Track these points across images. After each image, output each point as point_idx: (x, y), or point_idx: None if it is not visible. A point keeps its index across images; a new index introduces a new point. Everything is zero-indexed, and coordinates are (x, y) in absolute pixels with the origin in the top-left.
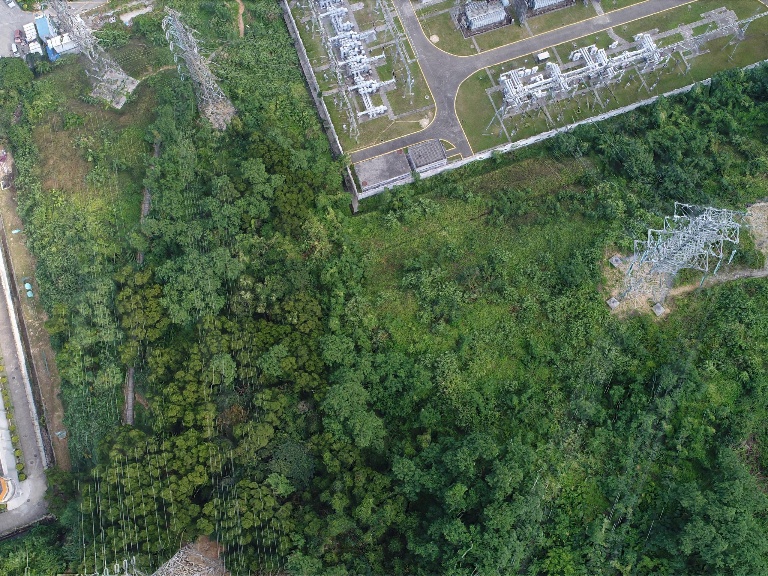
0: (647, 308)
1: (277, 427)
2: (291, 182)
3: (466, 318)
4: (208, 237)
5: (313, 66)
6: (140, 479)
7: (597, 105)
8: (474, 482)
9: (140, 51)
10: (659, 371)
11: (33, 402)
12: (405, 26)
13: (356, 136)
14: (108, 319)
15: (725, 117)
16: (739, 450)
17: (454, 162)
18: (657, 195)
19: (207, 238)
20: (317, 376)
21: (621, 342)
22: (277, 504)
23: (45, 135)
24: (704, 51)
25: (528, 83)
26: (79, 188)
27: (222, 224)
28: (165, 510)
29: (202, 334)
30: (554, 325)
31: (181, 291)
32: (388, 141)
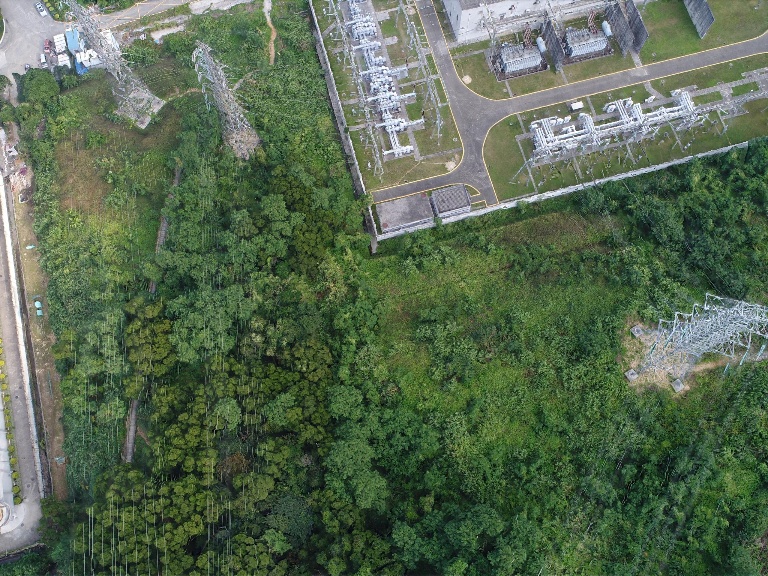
0: (666, 383)
1: (278, 478)
2: (311, 221)
3: (479, 379)
4: (222, 273)
5: (342, 99)
6: (135, 524)
7: (628, 160)
8: (475, 557)
9: (168, 71)
10: (674, 453)
11: (34, 424)
12: (438, 68)
13: (380, 175)
14: (115, 351)
15: (760, 186)
16: (752, 547)
17: (478, 210)
18: (684, 264)
19: (221, 274)
20: (322, 429)
21: (637, 417)
22: (272, 562)
23: (67, 153)
24: (743, 112)
25: (559, 133)
26: (97, 210)
27: (238, 260)
28: (158, 559)
29: (209, 372)
30: (569, 393)
31: (191, 329)
32: (412, 182)
